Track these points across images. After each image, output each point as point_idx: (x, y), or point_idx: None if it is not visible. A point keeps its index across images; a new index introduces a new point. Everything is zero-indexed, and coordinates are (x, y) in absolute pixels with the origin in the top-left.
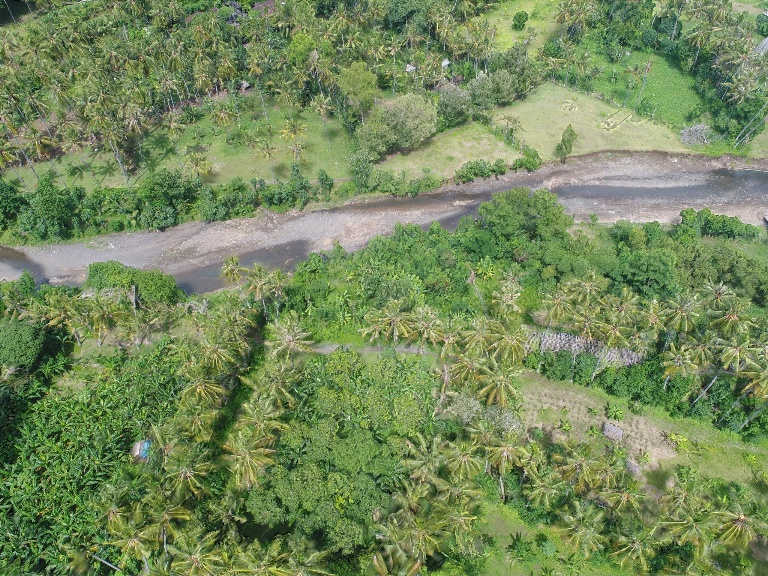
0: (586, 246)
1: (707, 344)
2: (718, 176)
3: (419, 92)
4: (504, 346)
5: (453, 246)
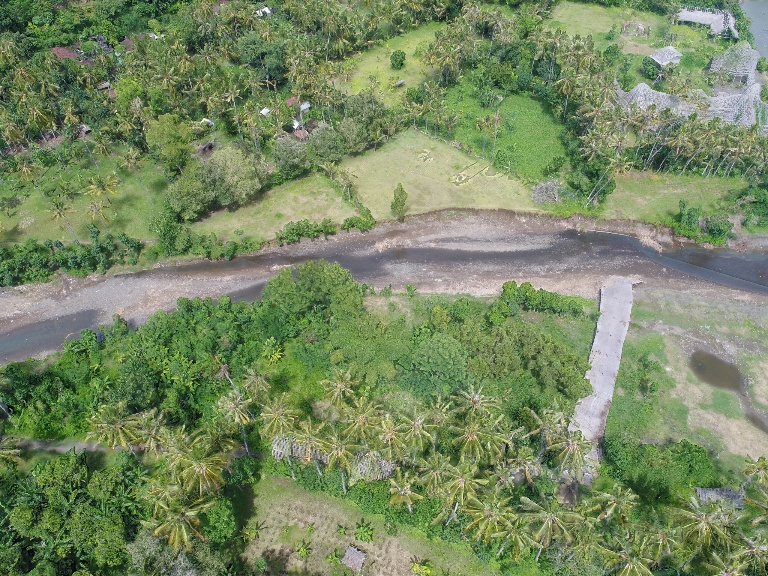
0: (377, 329)
1: (436, 470)
2: (565, 239)
3: (239, 146)
4: (188, 476)
5: (245, 322)
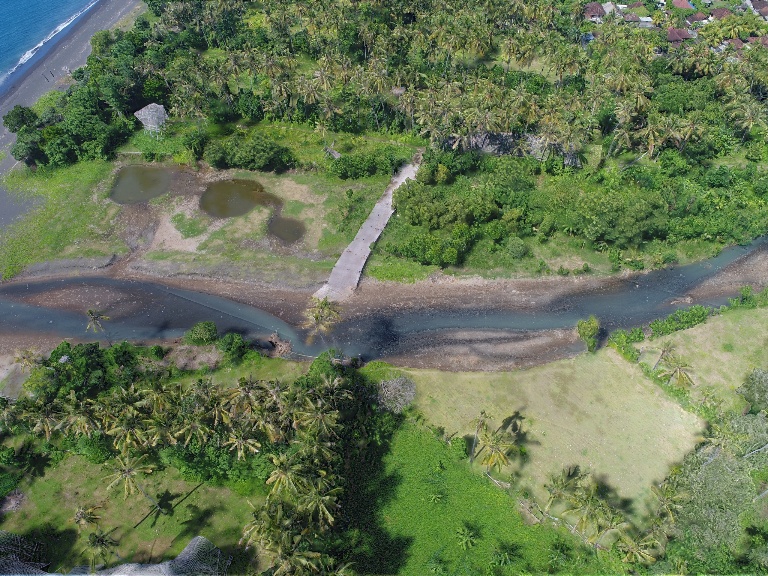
0: None
1: None
2: (378, 348)
3: None
4: None
5: None
